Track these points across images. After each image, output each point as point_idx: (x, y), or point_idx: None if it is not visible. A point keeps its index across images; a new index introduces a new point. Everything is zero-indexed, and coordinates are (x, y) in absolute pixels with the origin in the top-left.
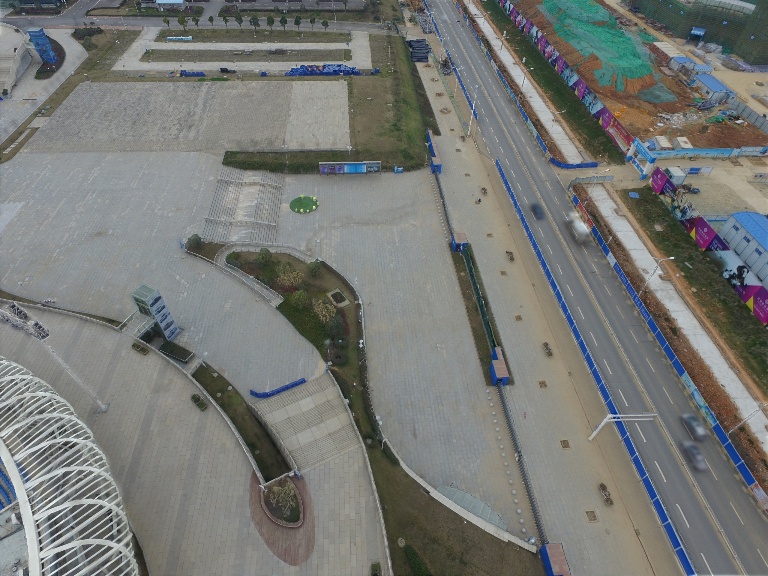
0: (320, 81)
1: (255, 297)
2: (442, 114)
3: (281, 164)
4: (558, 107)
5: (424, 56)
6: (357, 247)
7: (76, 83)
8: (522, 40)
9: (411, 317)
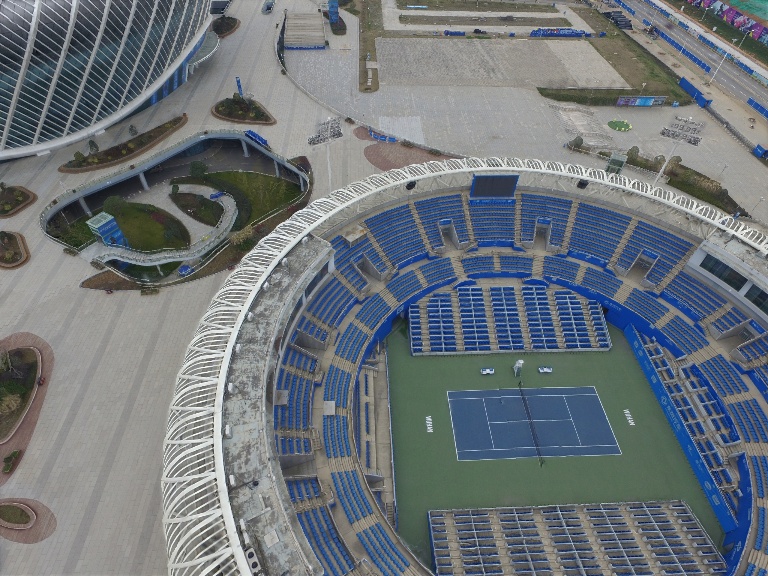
0: (566, 40)
1: (645, 177)
2: (675, 68)
3: (586, 97)
4: (767, 64)
5: (629, 24)
6: (683, 153)
7: (371, 38)
8: (700, 14)
9: (759, 195)
